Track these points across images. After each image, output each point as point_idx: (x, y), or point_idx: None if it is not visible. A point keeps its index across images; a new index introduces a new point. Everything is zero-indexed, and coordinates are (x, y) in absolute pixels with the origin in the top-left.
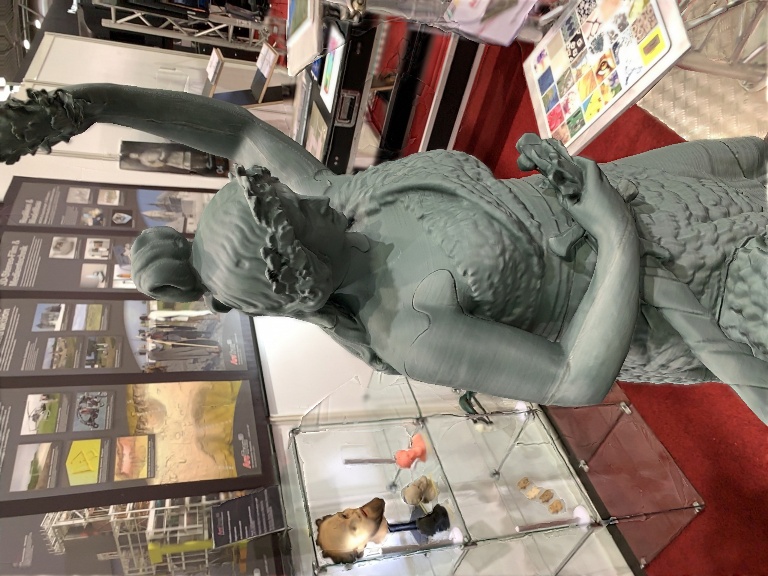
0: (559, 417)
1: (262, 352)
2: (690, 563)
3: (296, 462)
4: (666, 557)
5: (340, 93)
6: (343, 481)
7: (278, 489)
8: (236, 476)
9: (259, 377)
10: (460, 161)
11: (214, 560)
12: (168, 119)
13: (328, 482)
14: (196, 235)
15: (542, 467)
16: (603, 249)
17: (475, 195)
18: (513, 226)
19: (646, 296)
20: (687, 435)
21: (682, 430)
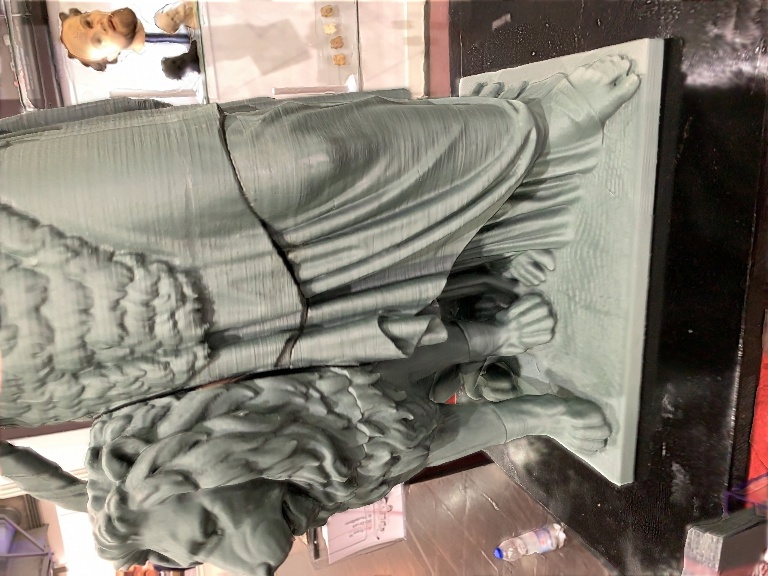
0: None
1: None
2: None
3: None
4: None
5: None
6: None
7: None
8: None
9: None
10: None
11: None
12: None
13: None
14: None
15: None
16: None
17: None
18: None
19: None
20: None
21: None
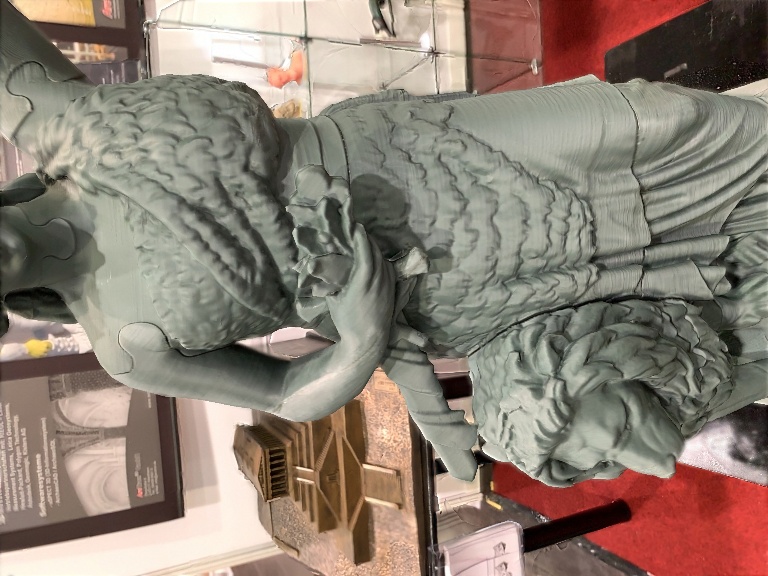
0: (479, 29)
1: None
2: None
3: None
4: None
5: None
6: None
7: (137, 67)
8: (94, 25)
9: None
10: (217, 160)
11: None
12: None
13: (202, 54)
14: None
15: None
16: (342, 349)
17: (207, 258)
18: (247, 302)
19: None
20: None
21: None
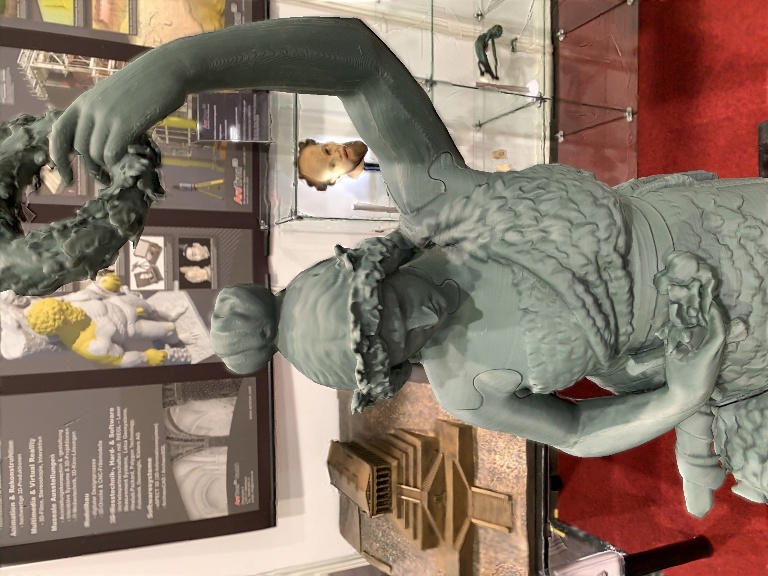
0: (565, 72)
1: None
2: None
3: (294, 104)
4: None
5: None
6: None
7: (268, 98)
8: None
9: None
10: (600, 242)
11: (196, 141)
12: (264, 84)
13: None
14: (287, 332)
15: (523, 123)
16: (667, 401)
17: (589, 322)
18: (604, 359)
19: None
20: (663, 172)
21: (662, 165)
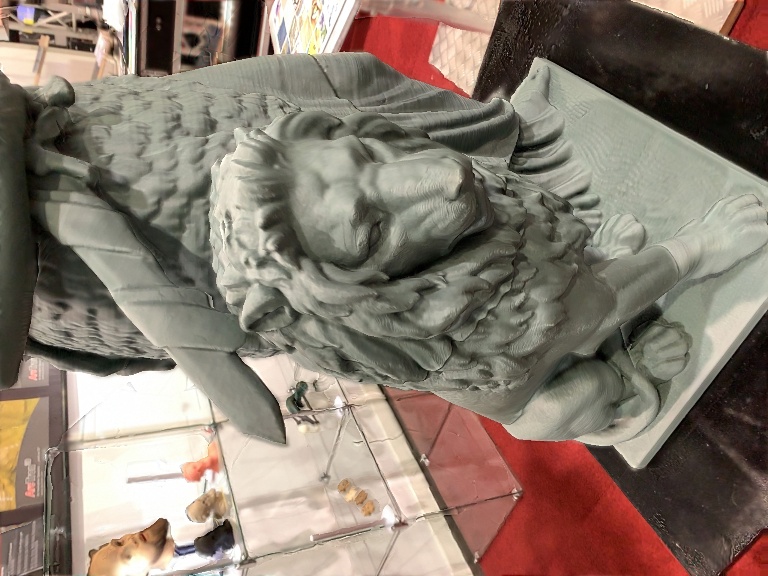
0: (407, 410)
1: None
2: (515, 553)
3: None
4: (495, 549)
5: (142, 74)
6: (151, 501)
7: None
8: (14, 508)
9: (62, 392)
10: None
11: None
12: None
13: (131, 504)
14: None
15: (383, 465)
16: None
17: None
18: None
19: (51, 231)
20: None
21: None
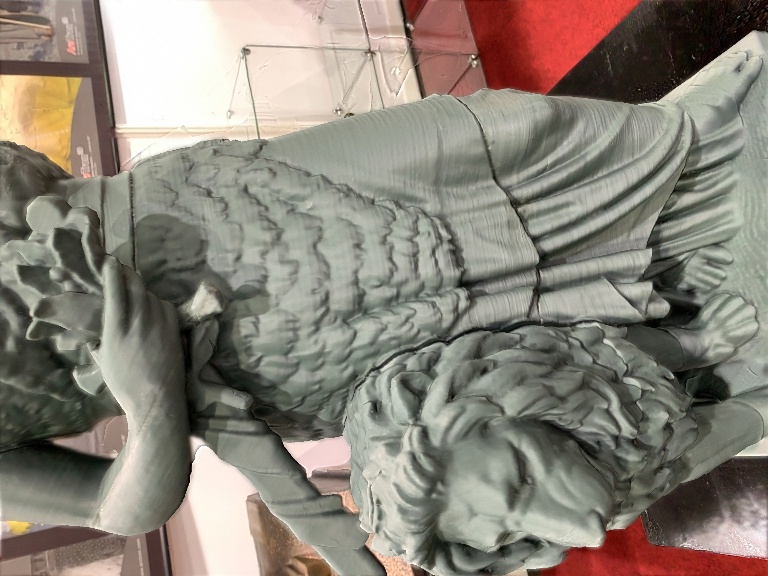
0: None
1: (109, 38)
2: None
3: None
4: None
5: None
6: None
7: None
8: None
9: (103, 74)
10: None
11: None
12: None
13: None
14: None
15: None
16: None
17: None
18: None
19: None
20: None
21: None
